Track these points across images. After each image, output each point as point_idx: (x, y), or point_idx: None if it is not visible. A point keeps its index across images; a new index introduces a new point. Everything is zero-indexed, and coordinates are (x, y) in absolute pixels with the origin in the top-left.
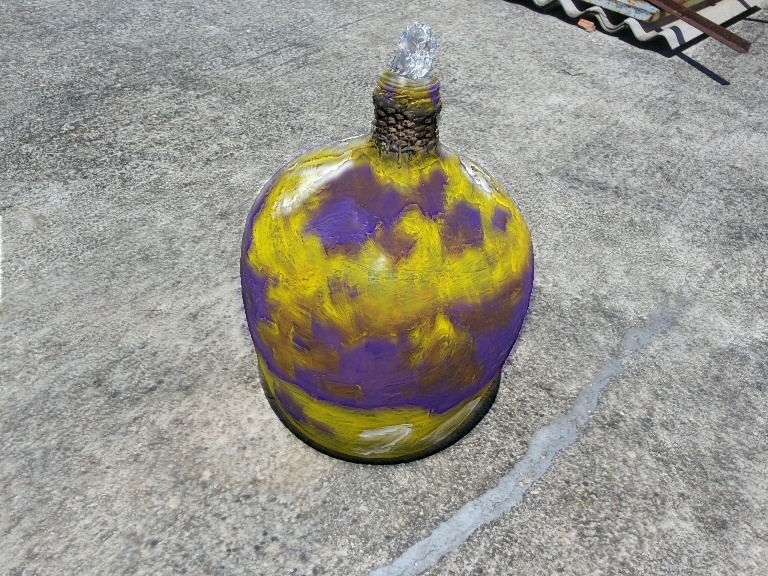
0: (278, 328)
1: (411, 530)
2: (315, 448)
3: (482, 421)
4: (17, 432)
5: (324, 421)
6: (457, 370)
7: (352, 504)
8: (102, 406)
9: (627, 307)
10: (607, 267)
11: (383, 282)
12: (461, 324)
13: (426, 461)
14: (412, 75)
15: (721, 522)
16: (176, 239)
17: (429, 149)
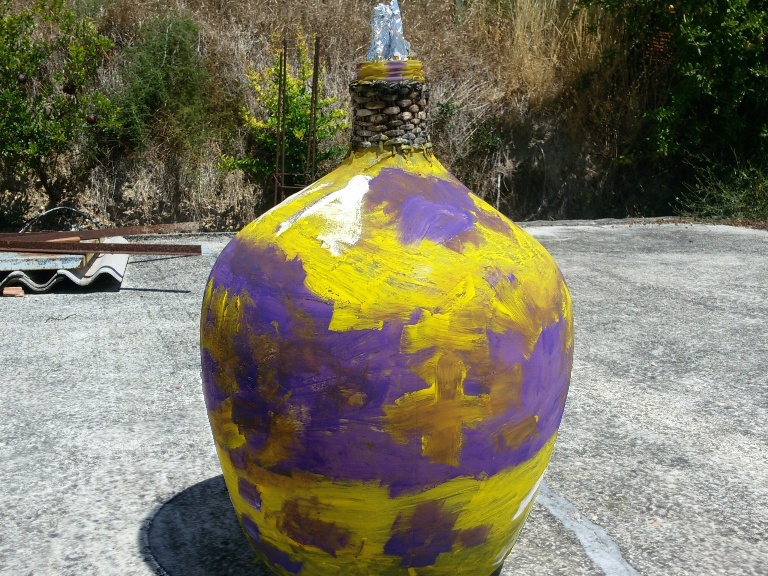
0: (438, 389)
1: None
2: None
3: None
4: None
5: (482, 521)
6: None
7: None
8: None
9: None
10: None
11: (525, 263)
12: None
13: (509, 556)
14: None
15: (680, 459)
16: None
17: None
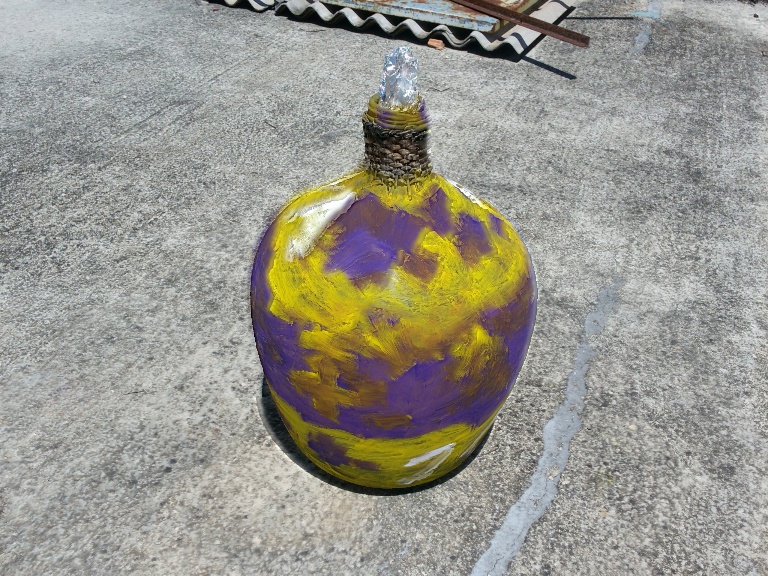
0: (320, 377)
1: (471, 545)
2: (351, 490)
3: (494, 428)
4: (42, 548)
5: (370, 460)
6: (496, 381)
7: (408, 535)
8: (122, 500)
9: (577, 296)
10: (546, 263)
11: (424, 310)
12: (498, 336)
13: (459, 477)
14: (411, 110)
15: (730, 469)
16: (130, 317)
17: (431, 178)
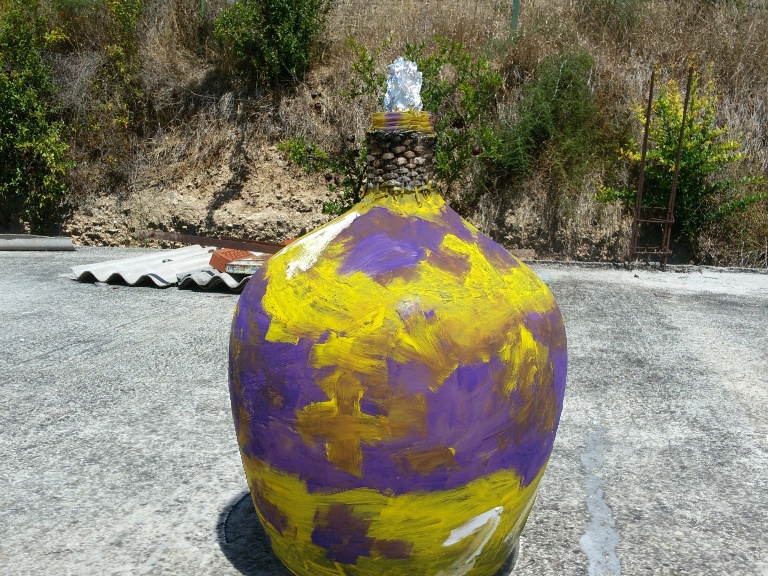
0: (337, 404)
1: None
2: None
3: (521, 546)
4: None
5: (399, 537)
6: (544, 409)
7: None
8: None
9: (562, 443)
10: None
11: (459, 302)
12: (542, 344)
13: None
14: (414, 112)
15: None
16: (44, 490)
17: (437, 193)
